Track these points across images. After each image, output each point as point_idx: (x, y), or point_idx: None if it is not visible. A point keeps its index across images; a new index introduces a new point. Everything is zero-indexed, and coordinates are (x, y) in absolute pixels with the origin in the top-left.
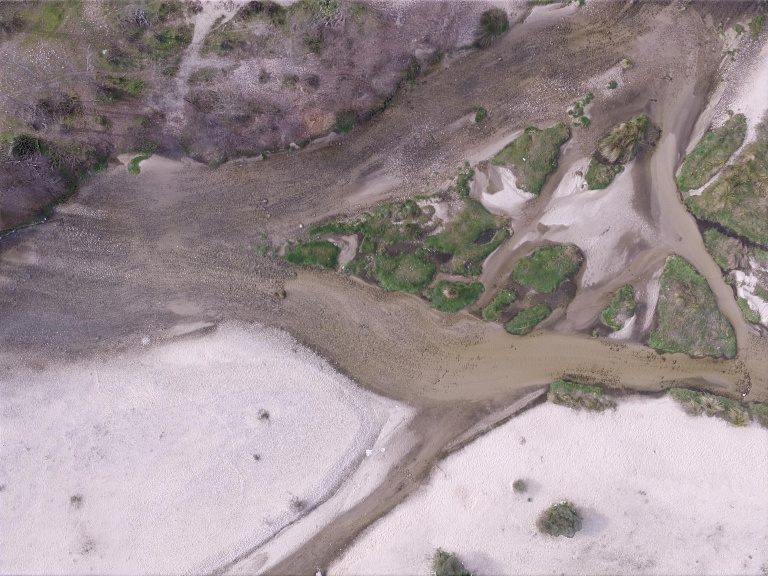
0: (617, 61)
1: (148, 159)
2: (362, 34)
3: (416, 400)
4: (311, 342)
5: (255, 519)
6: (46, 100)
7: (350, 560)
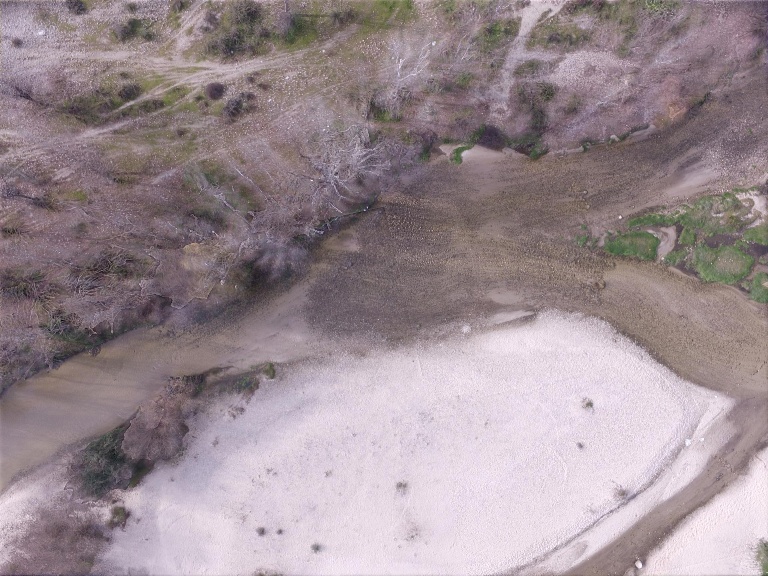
0: None
1: (470, 149)
2: (687, 29)
3: (735, 390)
4: (630, 332)
5: (578, 507)
6: (379, 90)
7: (670, 549)
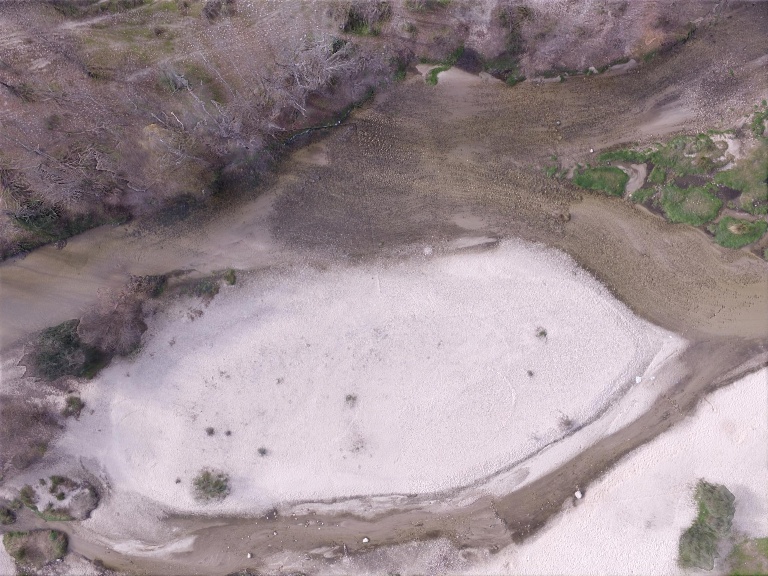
0: None
1: (447, 71)
2: None
3: (690, 332)
4: (591, 266)
5: (523, 433)
6: (358, 2)
7: (611, 482)
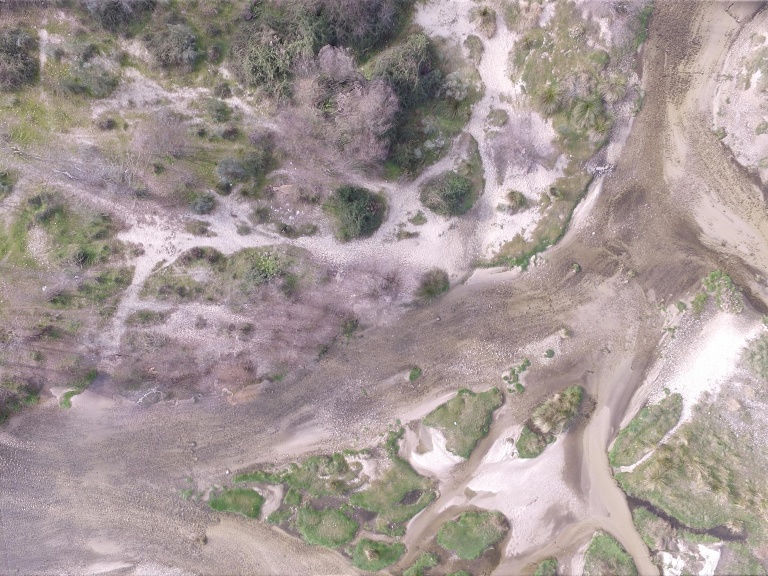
0: (556, 329)
1: (80, 394)
2: (301, 287)
3: None
4: None
5: None
6: None
7: None
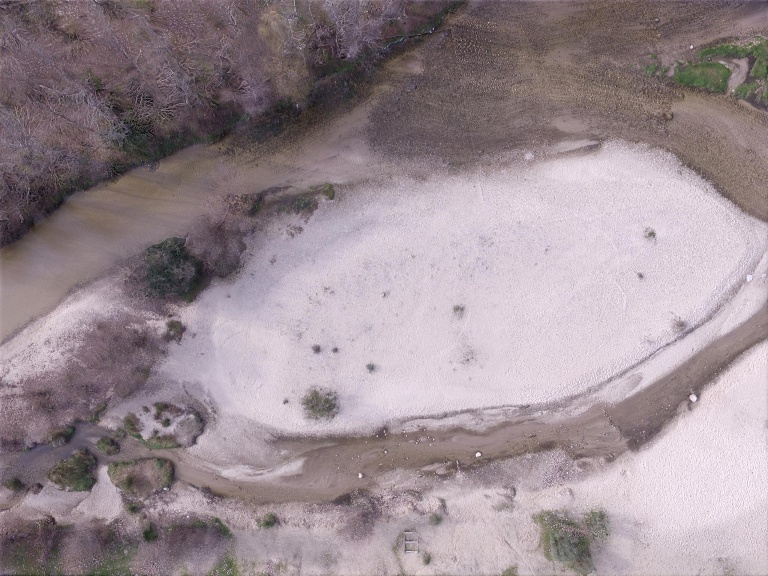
0: None
1: None
2: None
3: None
4: (696, 165)
5: (636, 337)
6: None
7: (726, 383)
